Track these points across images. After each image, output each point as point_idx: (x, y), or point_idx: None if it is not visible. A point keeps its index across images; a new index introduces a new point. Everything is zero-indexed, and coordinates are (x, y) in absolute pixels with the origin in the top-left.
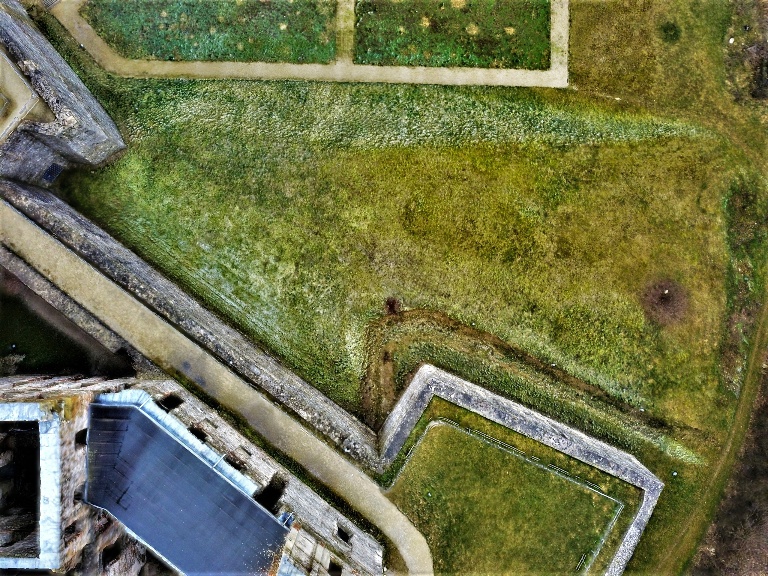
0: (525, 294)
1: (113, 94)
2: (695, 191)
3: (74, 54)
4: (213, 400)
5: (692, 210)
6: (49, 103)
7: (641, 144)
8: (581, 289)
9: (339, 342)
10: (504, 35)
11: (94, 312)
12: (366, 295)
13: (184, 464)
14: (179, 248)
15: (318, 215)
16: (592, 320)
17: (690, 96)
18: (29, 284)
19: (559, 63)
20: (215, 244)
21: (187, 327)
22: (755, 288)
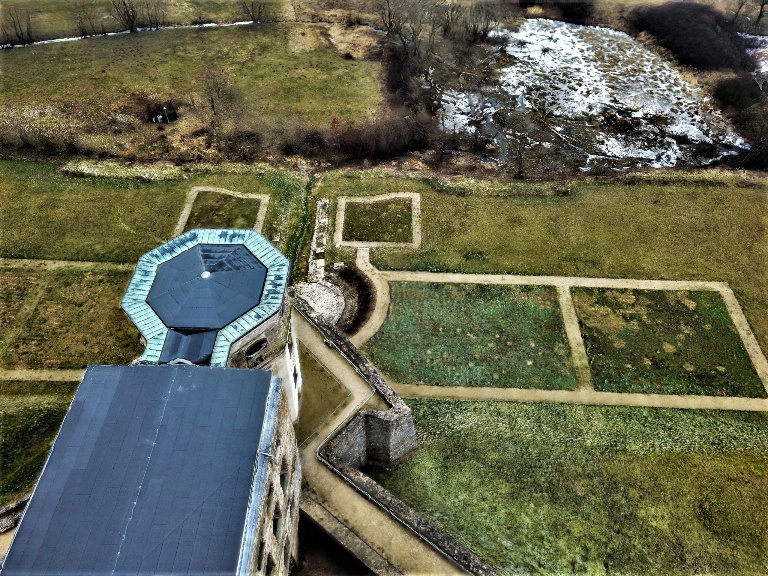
0: None
1: None
2: None
3: None
4: None
5: None
6: (386, 395)
7: None
8: None
9: None
10: (718, 372)
11: None
12: None
13: None
14: (480, 544)
15: (615, 513)
16: None
17: None
18: (366, 561)
19: None
20: (517, 541)
21: None
22: None
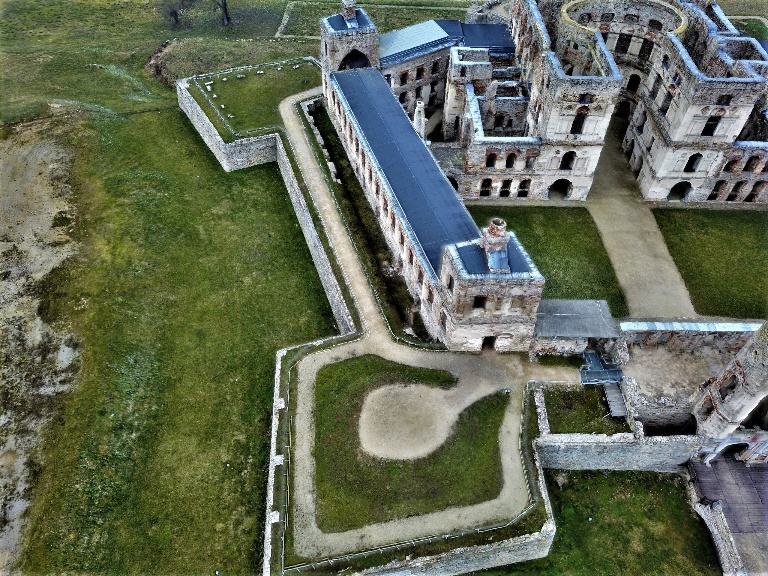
0: None
1: None
2: None
3: None
4: None
5: None
6: None
7: None
8: None
9: None
10: None
11: None
12: None
13: (758, 40)
14: None
15: None
16: None
17: None
18: None
19: None
20: None
21: None
22: None
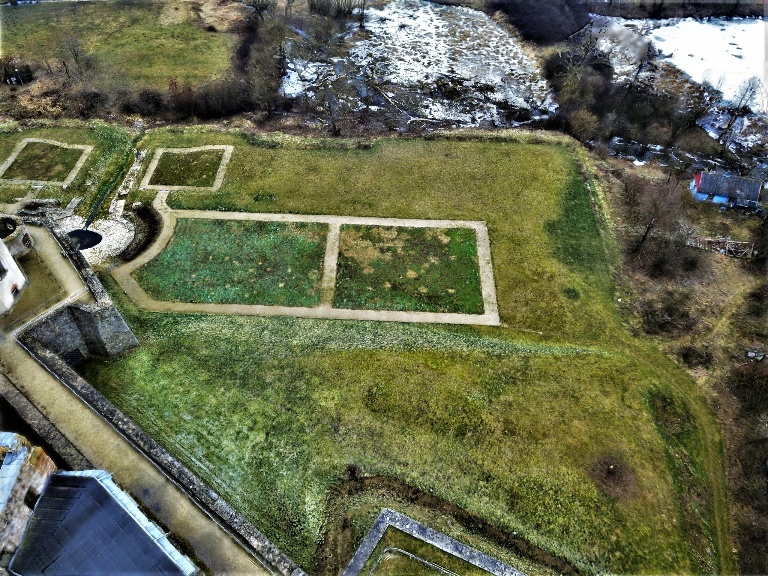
0: (479, 465)
1: (139, 320)
2: (618, 392)
3: (118, 296)
4: (164, 527)
5: (619, 405)
6: (95, 293)
7: (564, 357)
8: (531, 462)
9: (299, 501)
10: (447, 293)
11: (73, 442)
12: (329, 460)
13: (126, 533)
14: (163, 418)
15: (292, 396)
16: (546, 489)
17: (597, 332)
18: (24, 415)
19: (491, 311)
20: (196, 416)
21: (157, 454)
22: (697, 473)
